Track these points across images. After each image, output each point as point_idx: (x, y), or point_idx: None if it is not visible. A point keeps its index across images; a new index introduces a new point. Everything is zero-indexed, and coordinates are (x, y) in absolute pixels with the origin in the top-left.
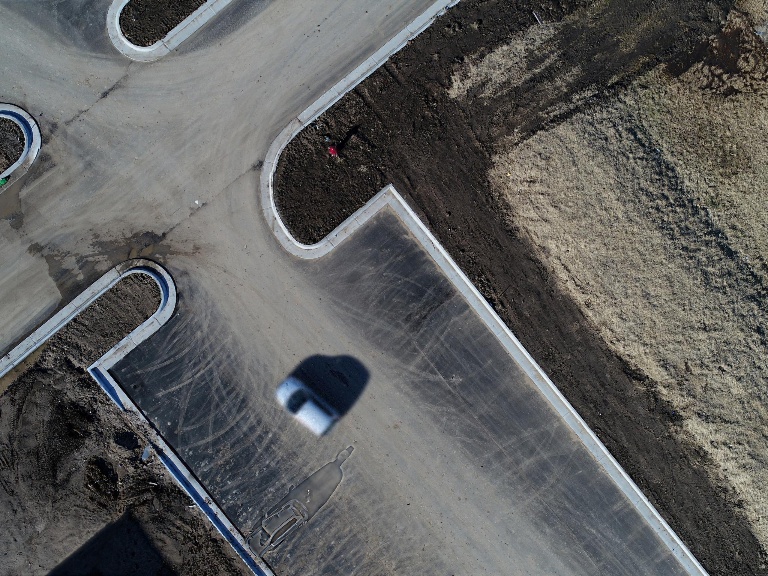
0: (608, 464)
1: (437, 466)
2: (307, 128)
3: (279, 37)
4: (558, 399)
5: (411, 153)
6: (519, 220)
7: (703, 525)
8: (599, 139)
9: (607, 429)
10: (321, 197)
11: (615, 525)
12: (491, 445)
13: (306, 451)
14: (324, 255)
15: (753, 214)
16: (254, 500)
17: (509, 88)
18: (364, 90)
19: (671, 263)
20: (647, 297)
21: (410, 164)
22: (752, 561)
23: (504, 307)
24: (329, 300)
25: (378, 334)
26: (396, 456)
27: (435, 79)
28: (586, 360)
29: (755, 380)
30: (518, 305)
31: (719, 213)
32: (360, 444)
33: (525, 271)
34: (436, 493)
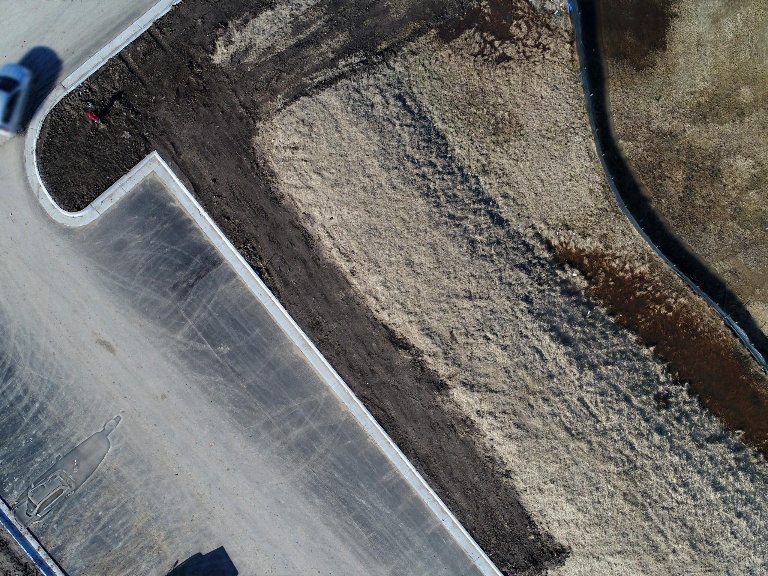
0: (377, 434)
1: (205, 436)
2: (70, 94)
3: (43, 2)
4: (326, 368)
5: (175, 119)
6: (284, 187)
7: (471, 495)
8: (364, 105)
9: (374, 398)
10: (85, 164)
11: (385, 495)
12: (260, 415)
13: (73, 421)
14: (90, 223)
15: (525, 182)
16: (20, 470)
17: (273, 53)
18: (128, 55)
19: (435, 231)
20: (411, 265)
21: (174, 130)
22: (521, 531)
23: (270, 275)
24: (96, 268)
25: (145, 303)
26: (164, 426)
27: (199, 44)
28: (352, 329)
29: (522, 349)
30: (284, 273)
31: (491, 181)
32: (128, 414)
33: (291, 239)
34: (204, 463)
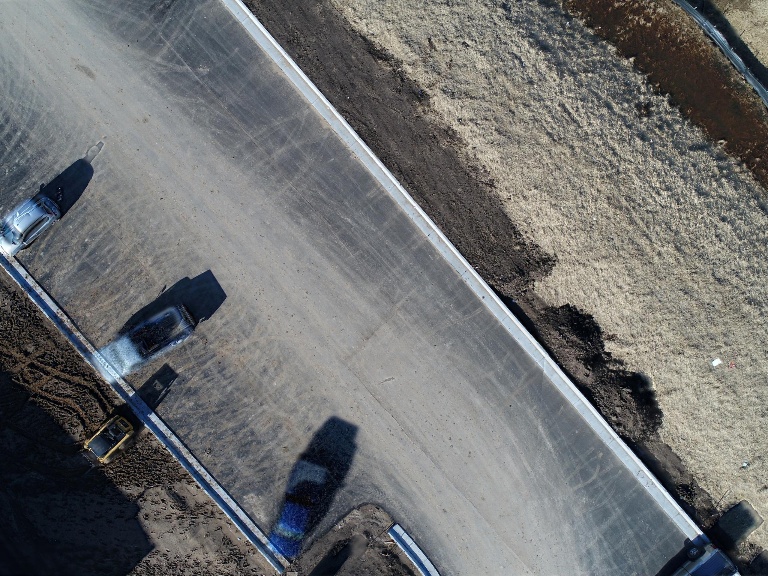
0: (359, 150)
1: (188, 159)
2: None
3: None
4: (306, 85)
5: None
6: None
7: (456, 207)
8: None
9: (356, 113)
10: None
11: (370, 213)
12: (242, 136)
13: (56, 148)
14: None
15: None
16: (5, 199)
17: None
18: None
19: None
20: None
21: None
22: (507, 242)
23: None
24: None
25: (123, 26)
26: (146, 150)
27: None
28: (331, 42)
29: (501, 56)
30: None
31: None
32: (110, 139)
33: None
34: (188, 186)
